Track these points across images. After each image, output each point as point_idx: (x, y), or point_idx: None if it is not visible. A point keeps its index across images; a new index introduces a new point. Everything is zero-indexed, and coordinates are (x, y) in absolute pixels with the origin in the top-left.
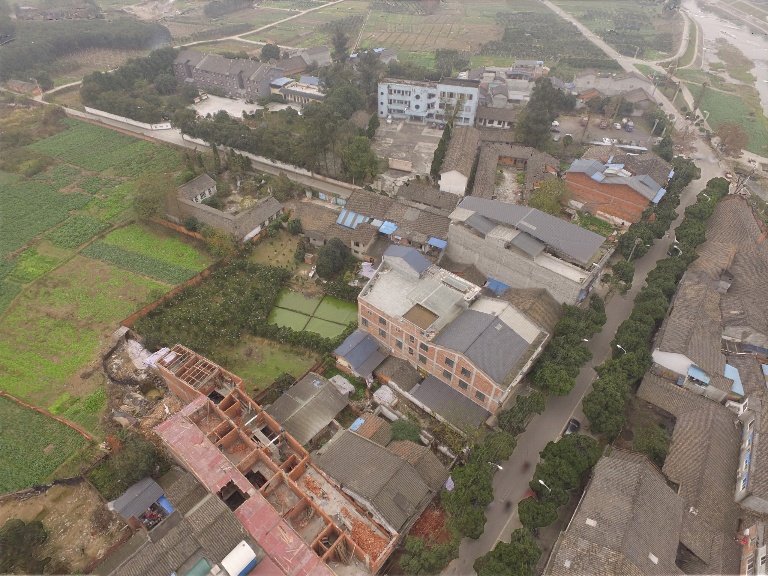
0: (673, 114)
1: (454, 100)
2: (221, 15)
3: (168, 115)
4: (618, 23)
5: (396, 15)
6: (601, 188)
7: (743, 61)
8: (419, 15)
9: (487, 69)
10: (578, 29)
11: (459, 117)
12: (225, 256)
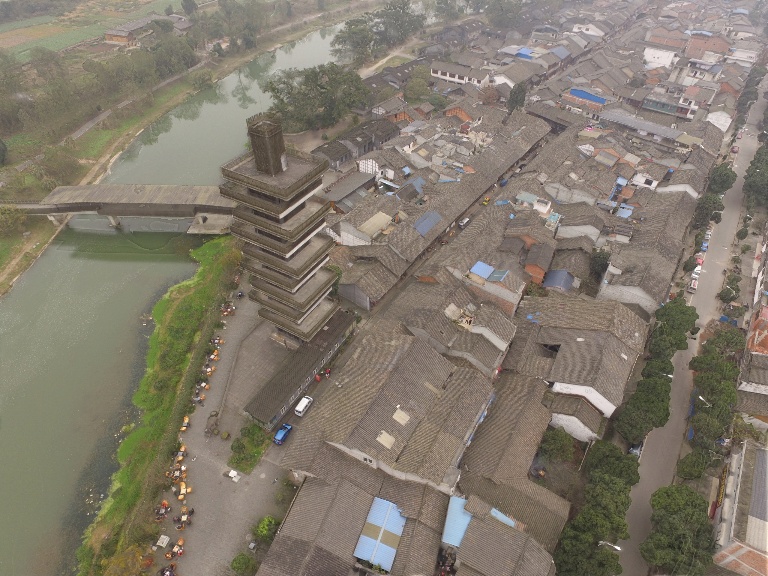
0: None
1: None
2: None
3: None
4: None
5: None
6: None
7: None
8: None
9: None
10: None
11: None
12: None
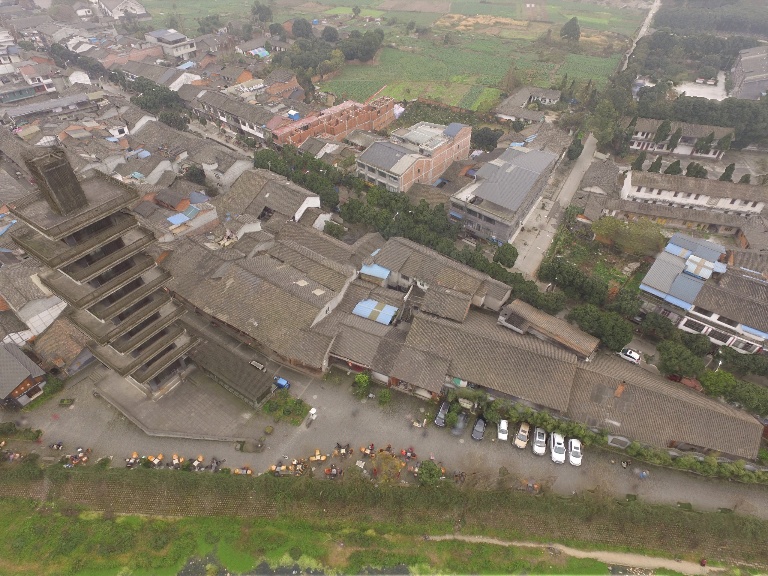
0: None
1: None
2: None
3: (654, 75)
4: None
5: None
6: None
7: None
8: None
9: None
10: None
11: None
12: (478, 112)
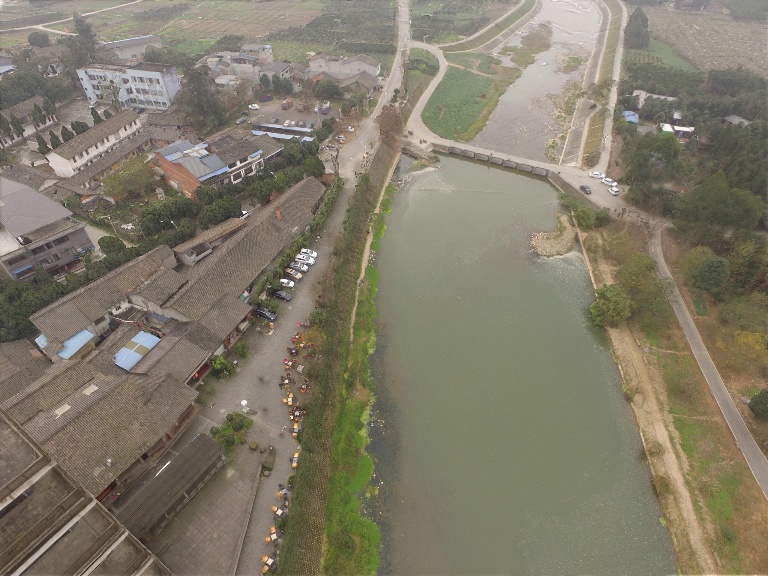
0: (371, 96)
1: (145, 85)
2: (51, 4)
3: None
4: (445, 8)
5: (232, 2)
6: (175, 168)
7: (540, 44)
8: (255, 2)
9: (218, 54)
10: (396, 14)
11: (157, 102)
12: None
